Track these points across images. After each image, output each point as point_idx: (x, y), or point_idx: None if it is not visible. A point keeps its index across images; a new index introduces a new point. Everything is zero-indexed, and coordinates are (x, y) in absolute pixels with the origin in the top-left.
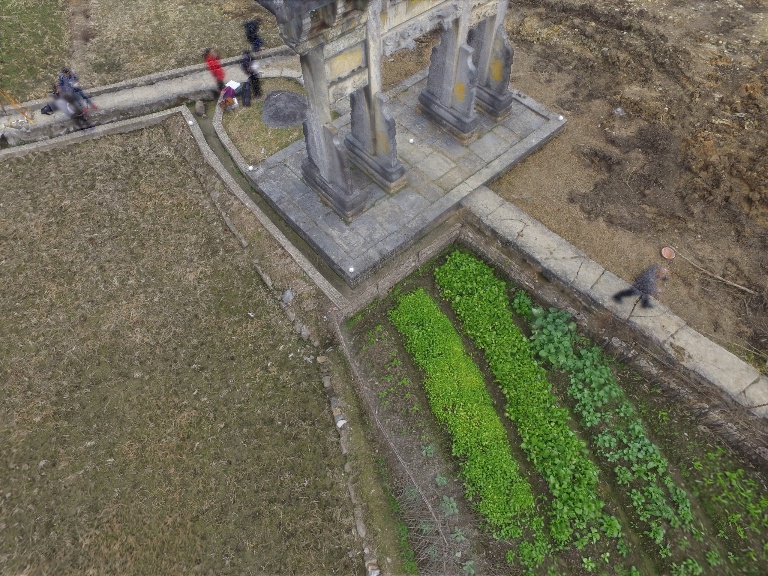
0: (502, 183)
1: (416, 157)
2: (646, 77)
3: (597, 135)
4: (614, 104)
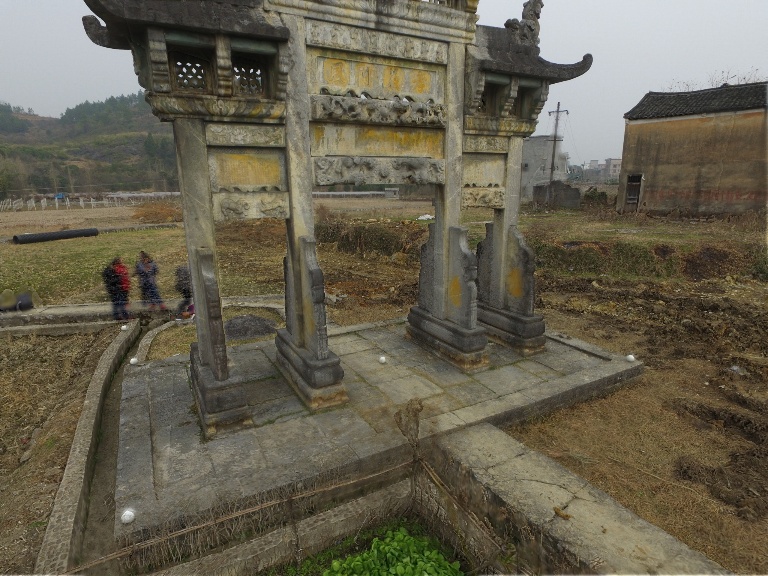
0: (528, 430)
1: (382, 377)
2: (765, 344)
3: (706, 393)
4: (723, 363)
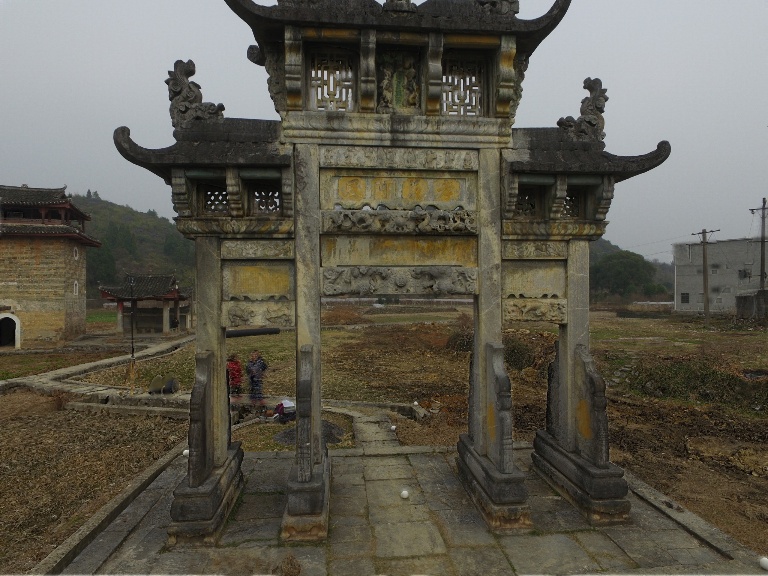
0: None
1: (389, 516)
2: None
3: None
4: None
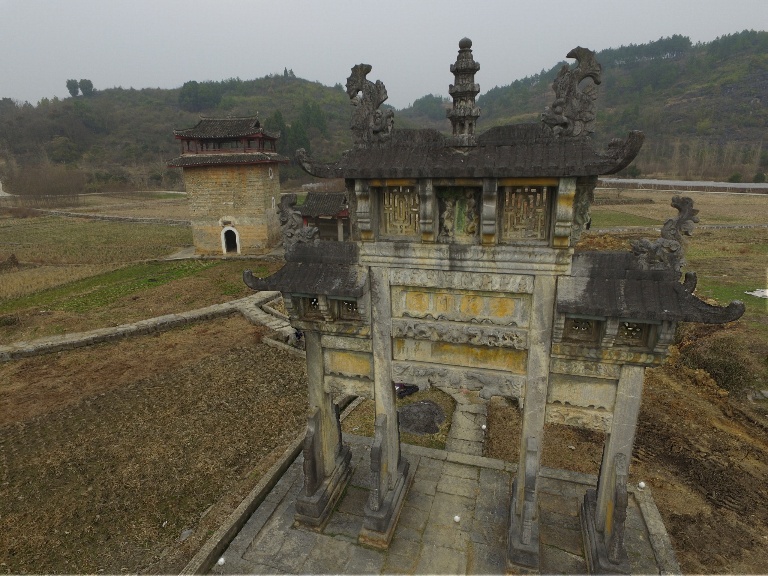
0: None
1: (438, 537)
2: None
3: None
4: None
